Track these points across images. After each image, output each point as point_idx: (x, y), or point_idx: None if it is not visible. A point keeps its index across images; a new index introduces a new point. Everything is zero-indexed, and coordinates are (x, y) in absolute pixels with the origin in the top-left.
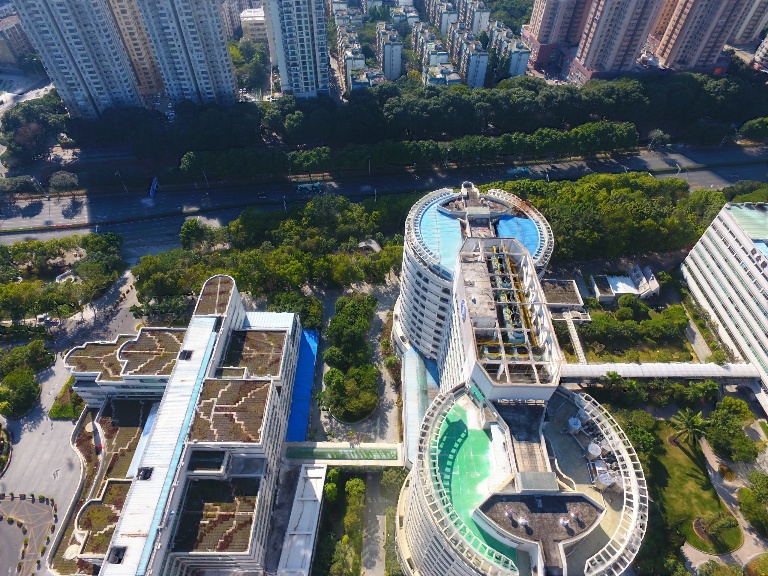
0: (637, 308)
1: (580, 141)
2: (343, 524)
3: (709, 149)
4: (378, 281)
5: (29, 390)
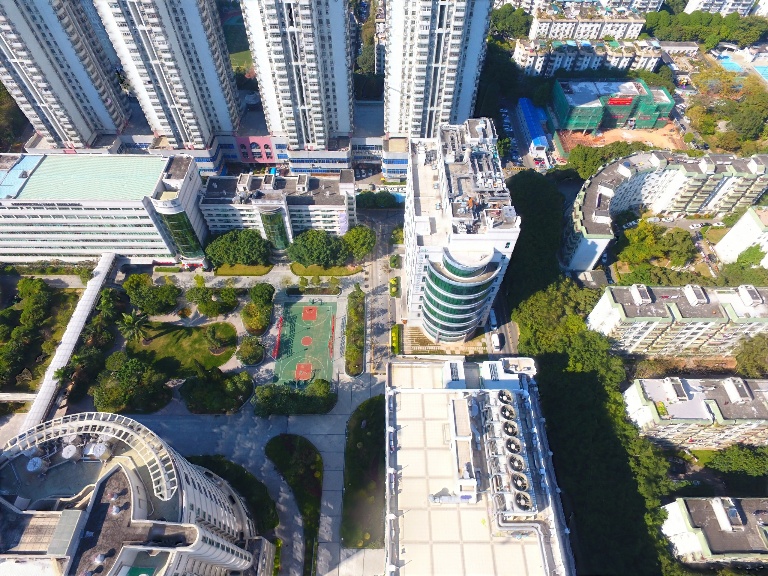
0: (2, 319)
1: None
2: None
3: None
4: None
5: None
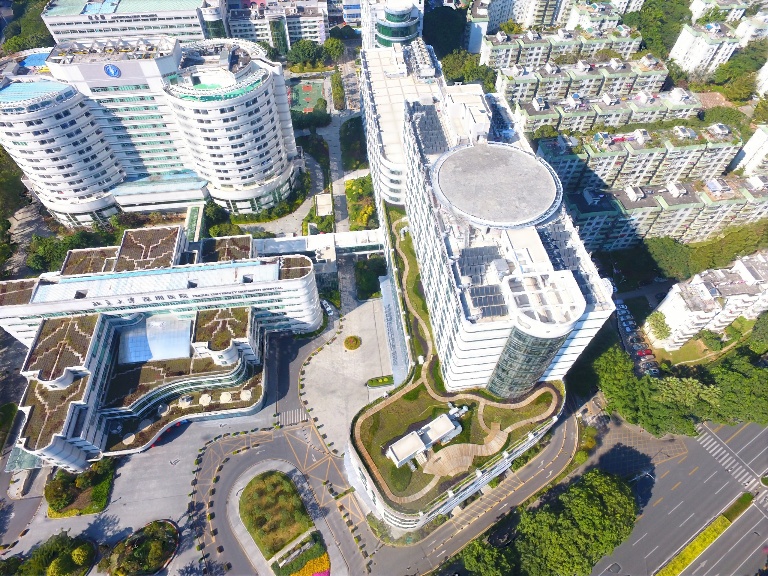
0: None
1: None
2: None
3: None
4: (12, 248)
5: (61, 535)
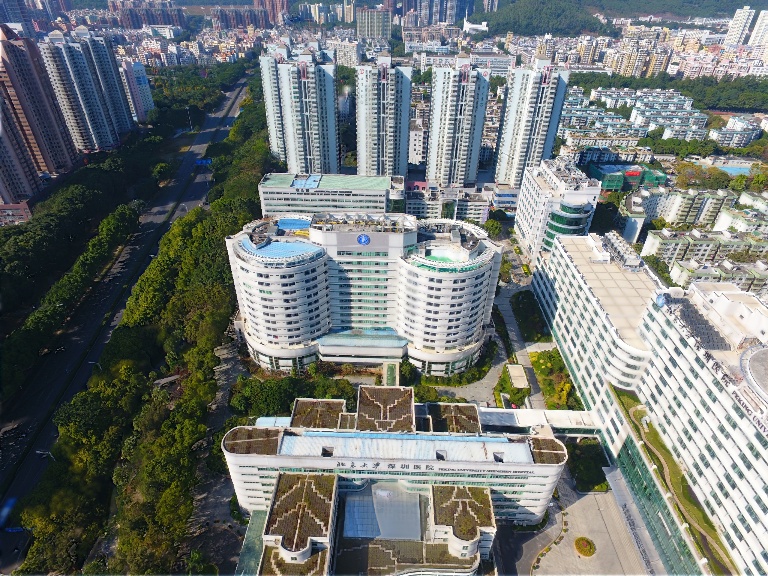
0: None
1: (118, 232)
2: (434, 402)
3: (158, 197)
4: None
5: None
